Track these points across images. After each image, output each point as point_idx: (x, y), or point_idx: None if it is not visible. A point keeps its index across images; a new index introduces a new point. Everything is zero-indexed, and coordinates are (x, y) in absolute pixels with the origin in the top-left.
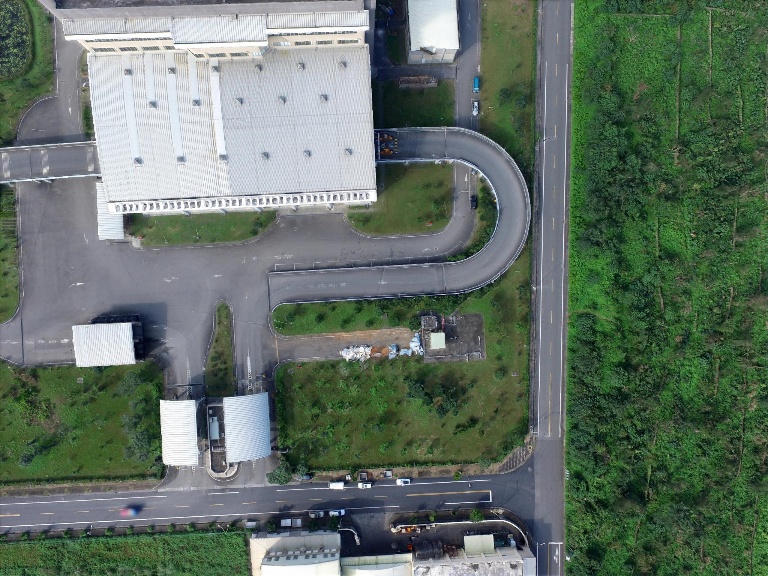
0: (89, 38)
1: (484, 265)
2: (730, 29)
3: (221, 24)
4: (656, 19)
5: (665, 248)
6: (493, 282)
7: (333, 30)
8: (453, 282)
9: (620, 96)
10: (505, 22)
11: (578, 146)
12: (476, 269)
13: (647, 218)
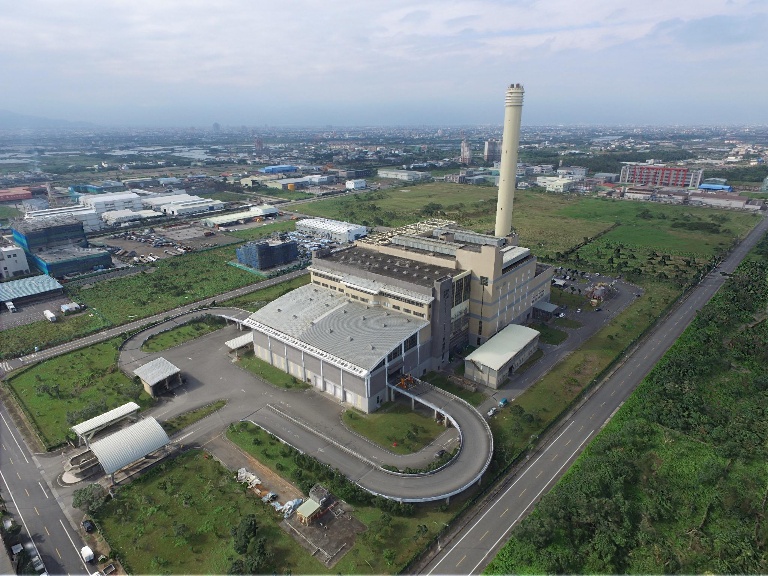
0: (314, 270)
1: (406, 487)
2: None
3: (365, 281)
4: (704, 446)
5: None
6: (401, 503)
7: (410, 297)
8: (369, 481)
9: None
10: (551, 390)
11: (571, 476)
12: (397, 485)
13: None
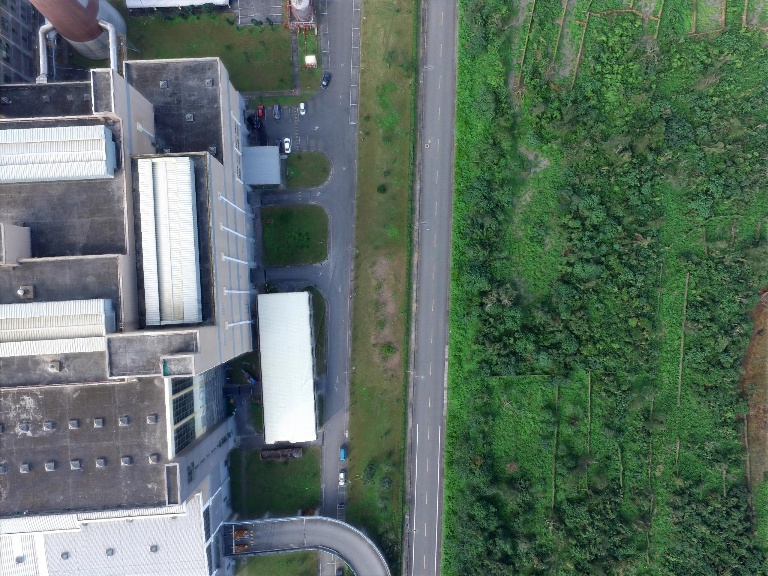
0: None
1: None
2: (610, 392)
3: (29, 519)
4: (534, 378)
5: None
6: None
7: None
8: None
9: (494, 462)
10: (374, 386)
11: (449, 514)
12: None
13: None
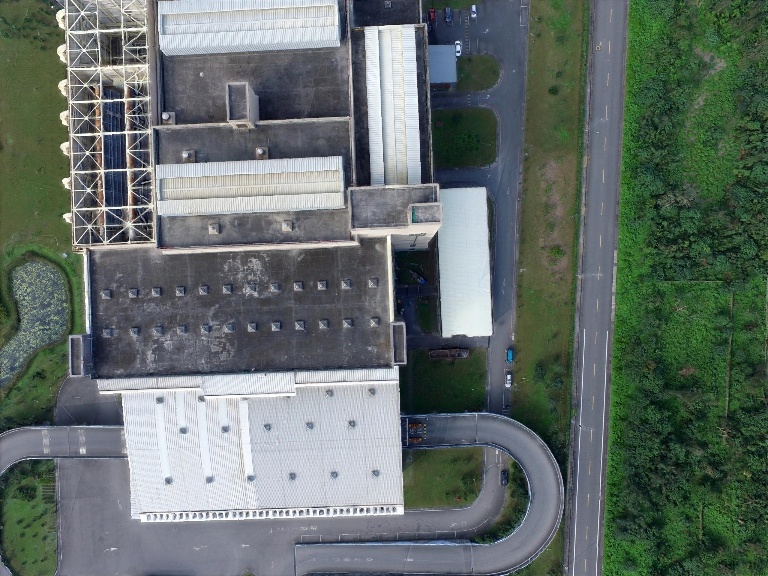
0: None
1: (514, 549)
2: None
3: (250, 380)
4: (706, 284)
5: (709, 529)
6: (523, 567)
7: (362, 384)
8: (481, 564)
9: (664, 368)
10: (542, 289)
11: (617, 420)
12: (505, 552)
13: (690, 496)
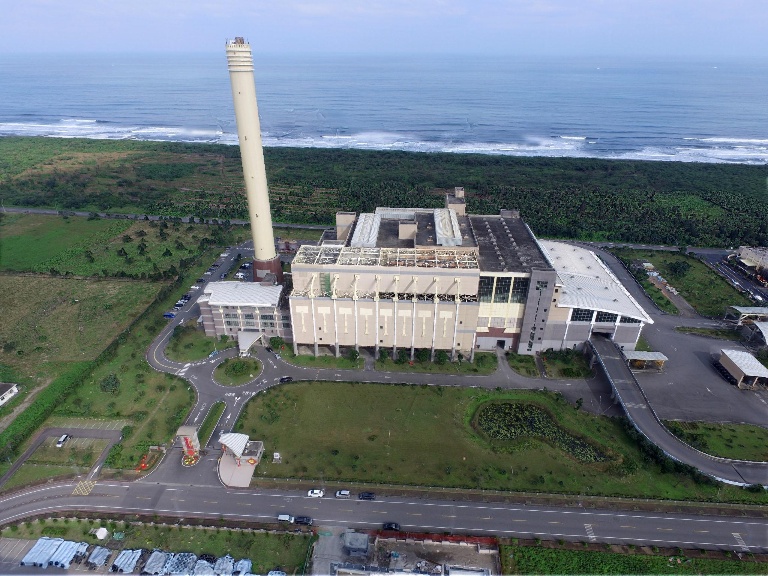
0: None
1: (600, 253)
2: None
3: None
4: None
5: None
6: None
7: None
8: None
9: None
10: None
11: None
12: (603, 255)
13: None
